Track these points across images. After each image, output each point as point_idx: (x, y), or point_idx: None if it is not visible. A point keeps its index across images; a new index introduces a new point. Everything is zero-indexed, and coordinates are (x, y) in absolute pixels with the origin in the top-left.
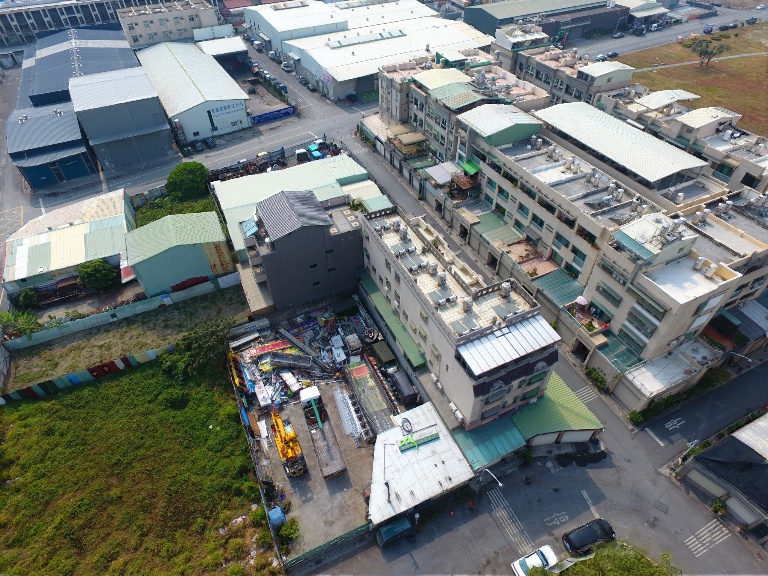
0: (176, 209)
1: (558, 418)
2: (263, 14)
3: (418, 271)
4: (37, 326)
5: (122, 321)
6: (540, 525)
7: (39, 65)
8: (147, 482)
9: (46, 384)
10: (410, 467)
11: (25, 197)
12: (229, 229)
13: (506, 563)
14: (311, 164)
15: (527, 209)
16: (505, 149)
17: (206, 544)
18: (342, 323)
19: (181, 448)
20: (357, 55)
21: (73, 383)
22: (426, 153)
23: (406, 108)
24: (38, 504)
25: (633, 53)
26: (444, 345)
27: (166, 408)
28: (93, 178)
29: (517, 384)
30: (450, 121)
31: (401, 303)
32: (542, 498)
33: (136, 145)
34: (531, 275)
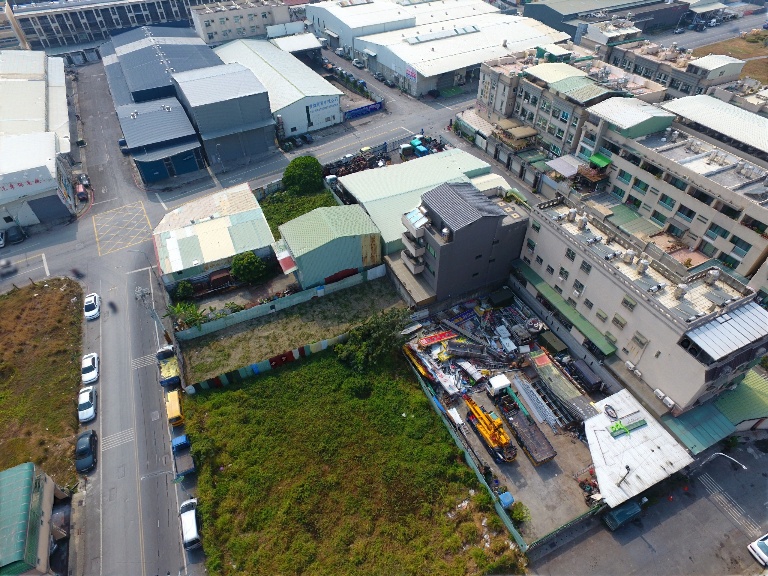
0: (298, 203)
1: (760, 404)
2: (331, 11)
3: (611, 260)
4: (203, 317)
5: (280, 312)
6: (761, 509)
7: (124, 62)
8: (360, 468)
9: (232, 373)
10: (628, 452)
11: (141, 192)
12: (374, 221)
13: (740, 546)
14: (428, 158)
15: (672, 200)
16: (639, 141)
17: (440, 528)
18: (504, 313)
19: (381, 435)
20: (437, 51)
21: (254, 373)
22: (534, 147)
23: (511, 102)
24: (260, 490)
25: (699, 48)
26: (660, 332)
27: (352, 397)
28: (202, 173)
29: (735, 370)
30: (574, 114)
31: (584, 292)
32: (754, 483)
33: (242, 140)
34: (687, 265)
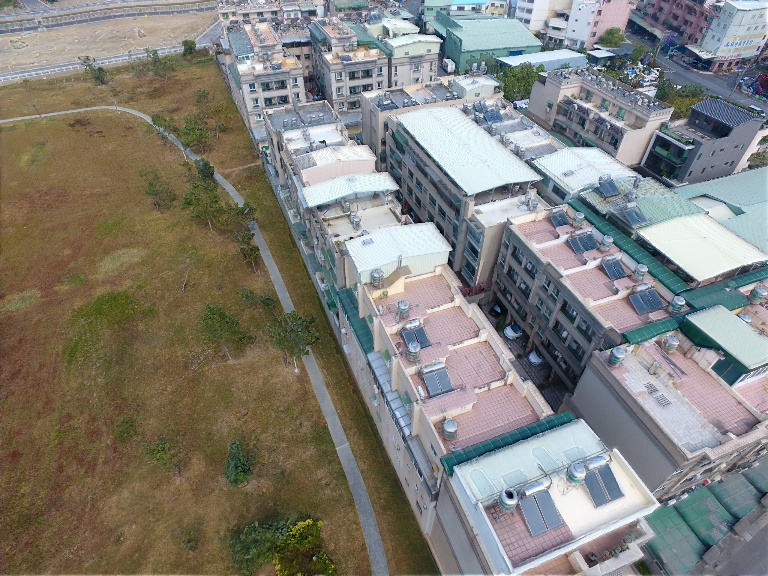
0: None
1: None
2: None
3: None
4: None
5: None
6: None
7: None
8: None
9: None
10: None
11: None
12: None
13: None
14: None
15: None
16: None
17: None
18: None
19: None
20: None
21: None
22: None
23: None
24: None
25: None
26: None
27: None
28: None
29: None
30: None
31: None
32: None
33: None
34: None
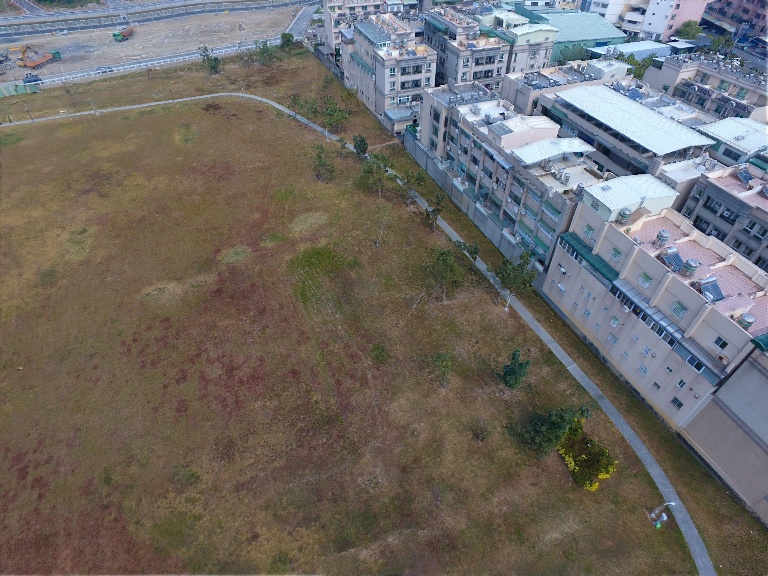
0: None
1: None
2: None
3: None
4: None
5: None
6: None
7: None
8: None
9: None
10: None
11: None
12: None
13: None
14: None
15: None
16: None
17: None
18: None
19: None
20: None
21: None
22: None
23: None
24: None
25: None
26: None
27: None
28: None
29: None
30: None
31: None
32: None
33: None
34: None
